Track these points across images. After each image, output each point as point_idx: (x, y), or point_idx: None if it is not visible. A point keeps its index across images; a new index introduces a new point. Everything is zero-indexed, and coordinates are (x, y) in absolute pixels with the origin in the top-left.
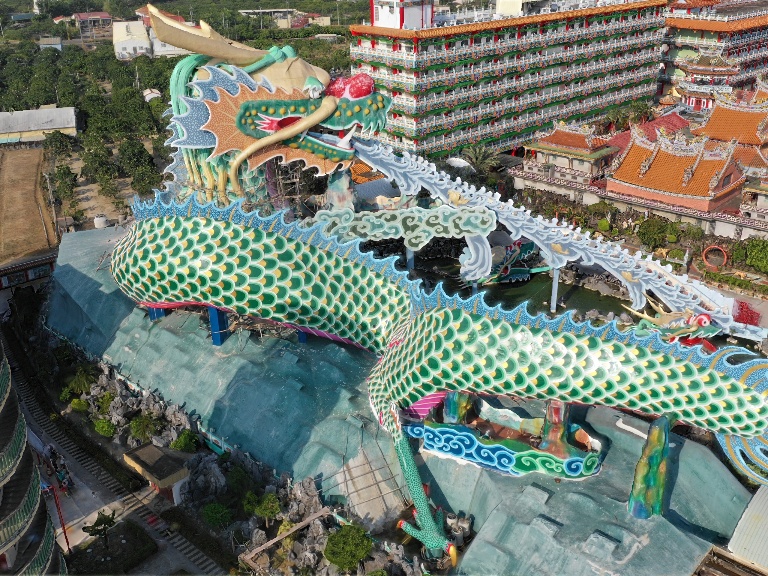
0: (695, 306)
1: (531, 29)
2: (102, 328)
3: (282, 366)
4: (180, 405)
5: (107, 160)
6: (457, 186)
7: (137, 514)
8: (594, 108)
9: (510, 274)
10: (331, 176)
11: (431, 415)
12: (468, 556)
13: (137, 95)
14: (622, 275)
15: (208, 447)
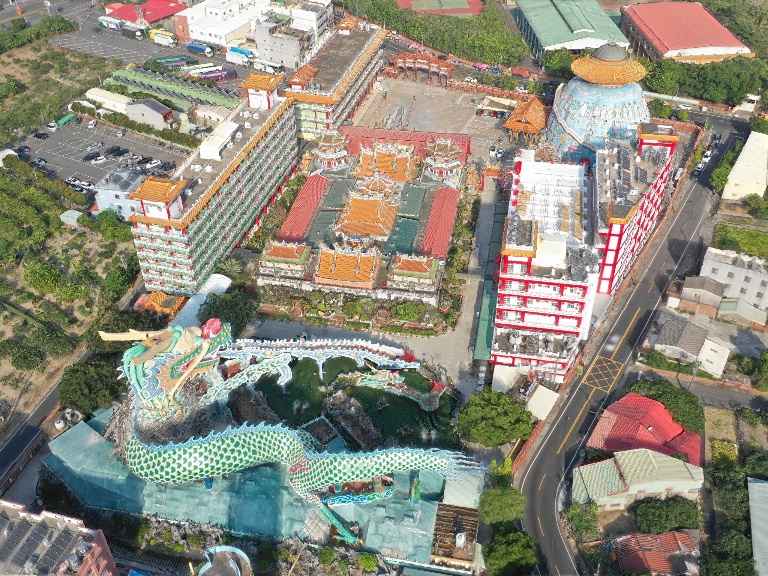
0: (387, 360)
1: None
2: (134, 498)
3: (250, 489)
4: (207, 523)
5: None
6: (265, 344)
7: None
8: (271, 188)
9: None
10: None
11: (329, 492)
12: (368, 541)
13: None
14: (352, 356)
15: (232, 536)
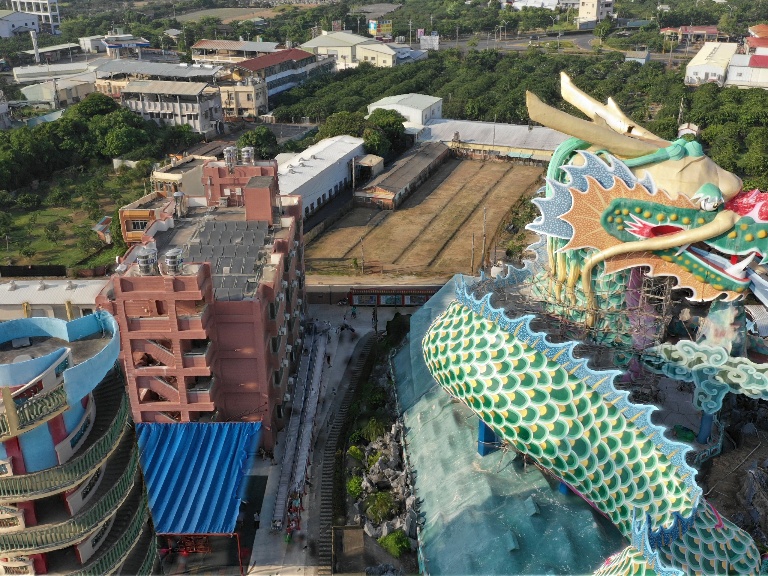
0: None
1: None
2: (416, 385)
3: (516, 512)
4: (420, 499)
5: None
6: None
7: None
8: None
9: None
10: (714, 303)
11: None
12: None
13: (671, 128)
14: None
15: (417, 557)
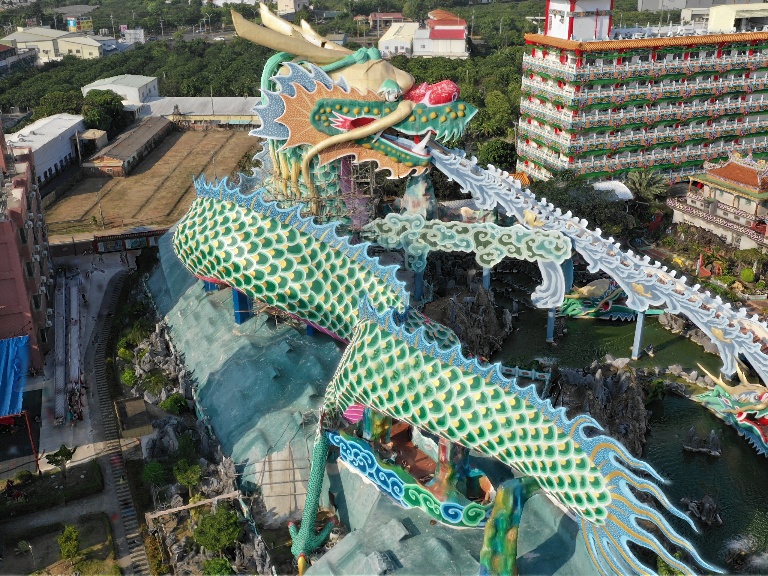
0: None
1: (736, 48)
2: (172, 292)
3: (274, 353)
4: (191, 371)
5: None
6: (541, 207)
7: (110, 457)
8: None
9: (611, 311)
10: (409, 180)
11: (354, 427)
12: (309, 571)
13: None
14: (712, 331)
15: (196, 414)
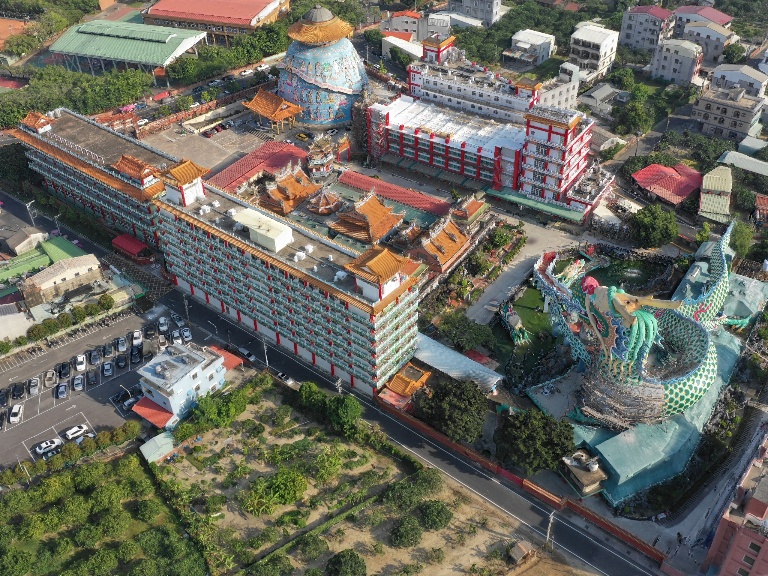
0: None
1: None
2: None
3: None
4: (719, 394)
5: None
6: None
7: (764, 402)
8: None
9: None
10: None
11: None
12: None
13: None
14: None
15: None
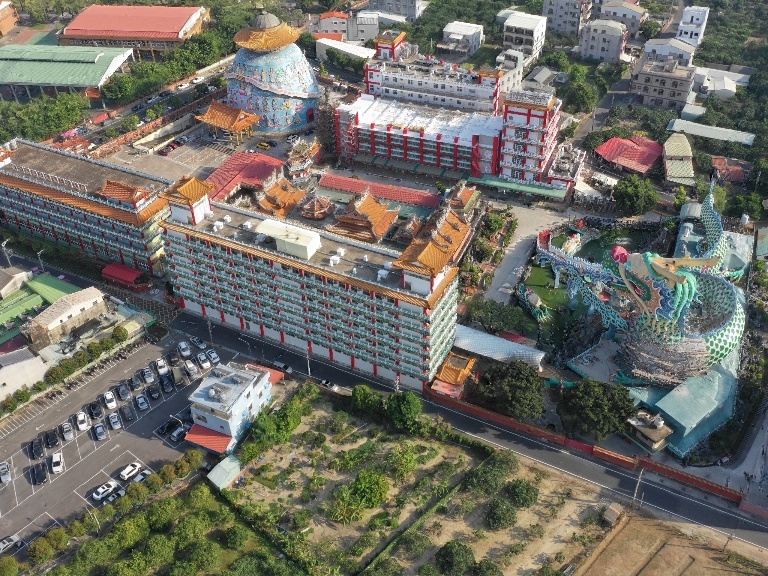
0: None
1: None
2: None
3: None
4: (740, 341)
5: (481, 569)
6: None
7: None
8: None
9: None
10: None
11: None
12: None
13: None
14: None
15: None
